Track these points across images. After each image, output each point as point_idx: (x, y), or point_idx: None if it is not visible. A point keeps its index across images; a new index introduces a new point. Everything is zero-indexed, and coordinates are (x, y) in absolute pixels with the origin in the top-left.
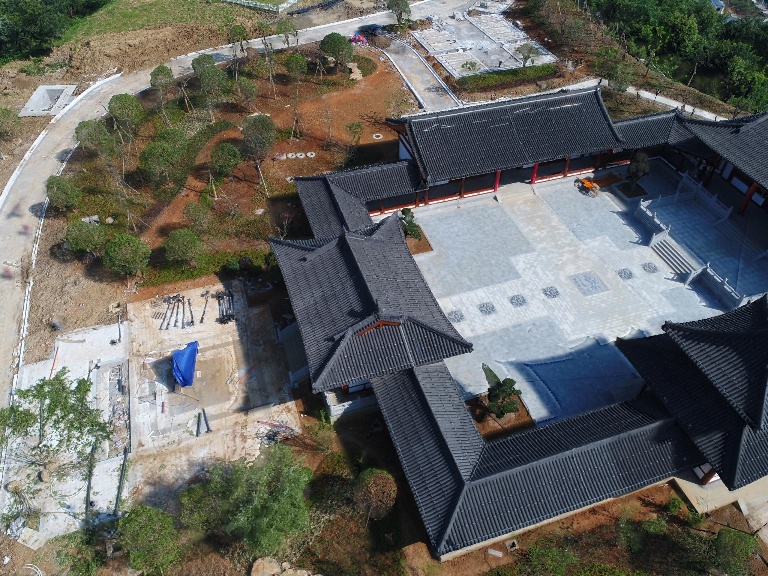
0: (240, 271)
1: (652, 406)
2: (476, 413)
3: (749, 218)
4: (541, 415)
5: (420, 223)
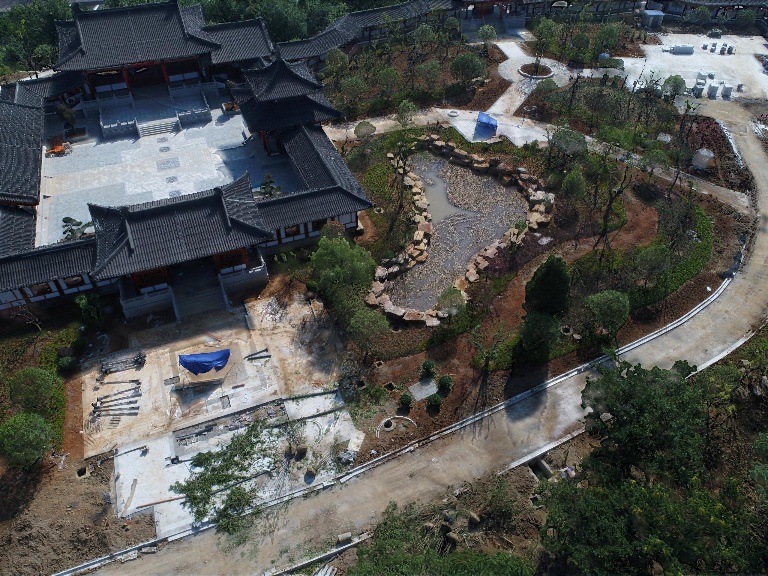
0: None
1: (290, 134)
2: None
3: (137, 94)
4: None
5: None
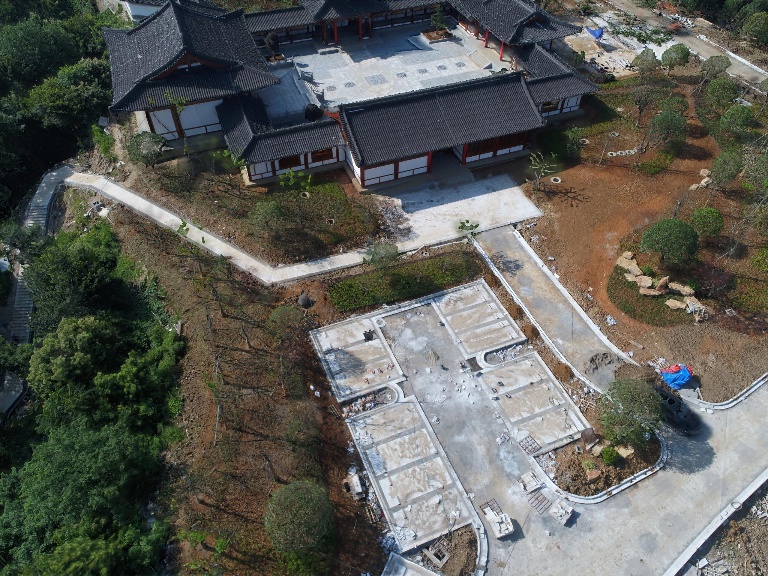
0: None
1: None
2: (448, 34)
3: None
4: None
5: None
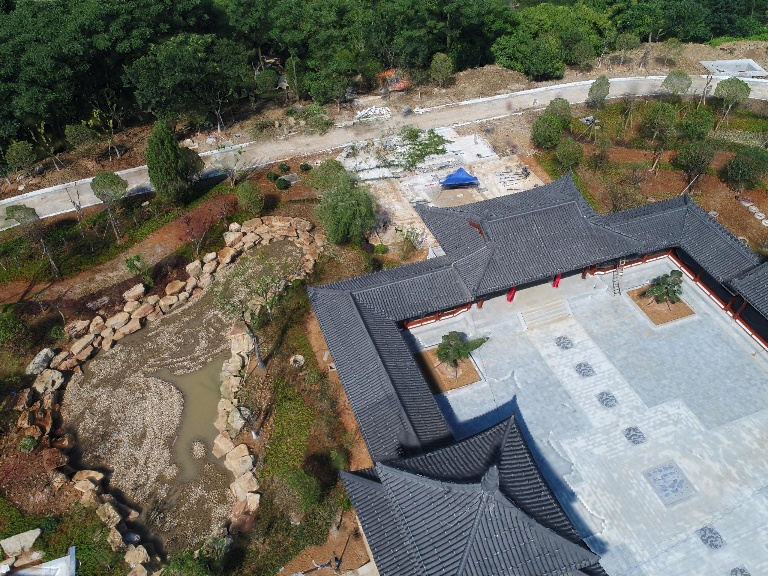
0: None
1: None
2: None
3: None
4: (455, 402)
5: (701, 317)
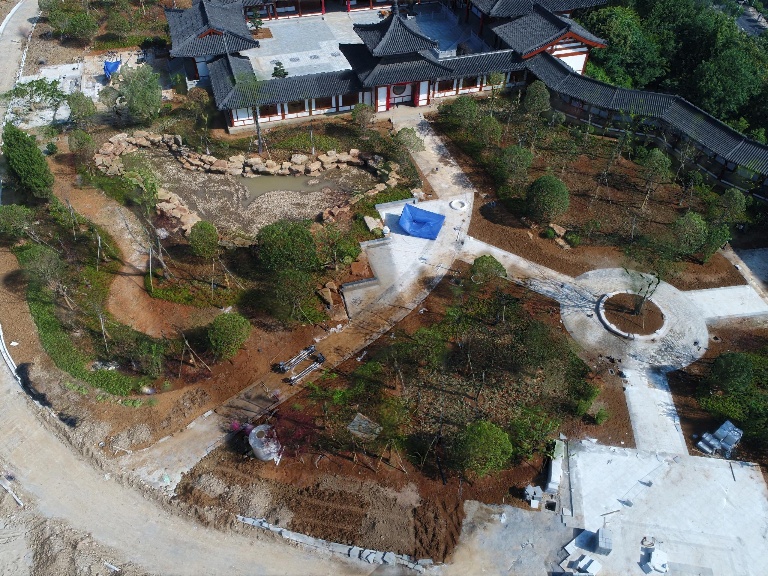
0: (153, 45)
1: None
2: None
3: (471, 25)
4: None
5: (271, 28)
